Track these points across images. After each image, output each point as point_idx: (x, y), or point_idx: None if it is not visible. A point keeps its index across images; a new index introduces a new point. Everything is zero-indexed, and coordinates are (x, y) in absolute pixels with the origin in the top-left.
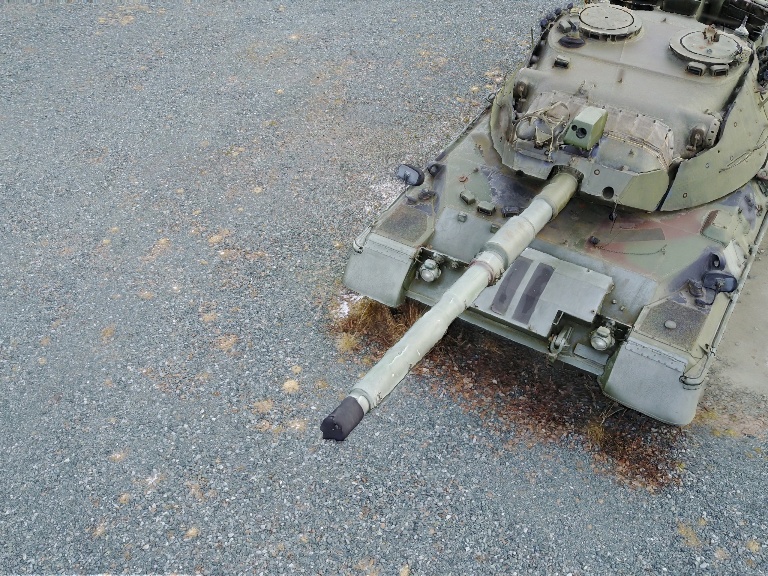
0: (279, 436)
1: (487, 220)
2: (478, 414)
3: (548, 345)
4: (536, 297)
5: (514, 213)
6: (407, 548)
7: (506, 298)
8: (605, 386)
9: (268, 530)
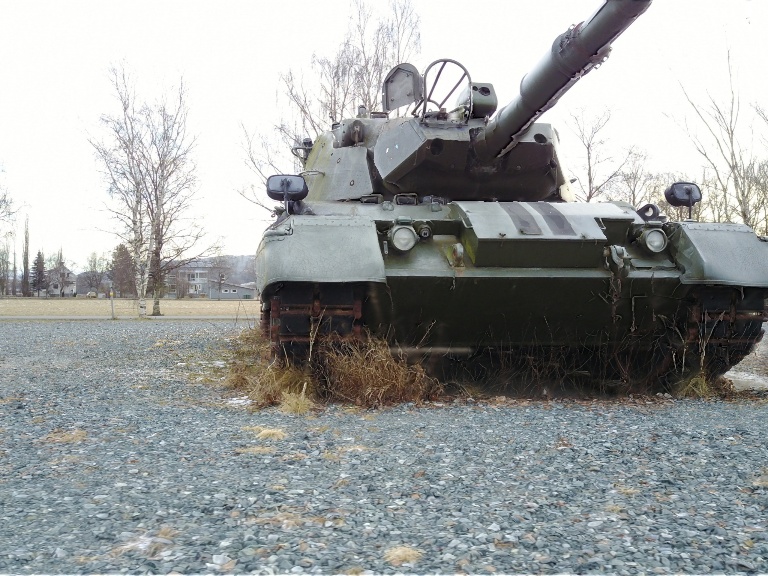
0: (345, 458)
1: None
2: (566, 408)
3: (607, 261)
4: (559, 214)
5: (439, 200)
6: (763, 460)
7: (528, 222)
8: (705, 269)
9: (548, 504)
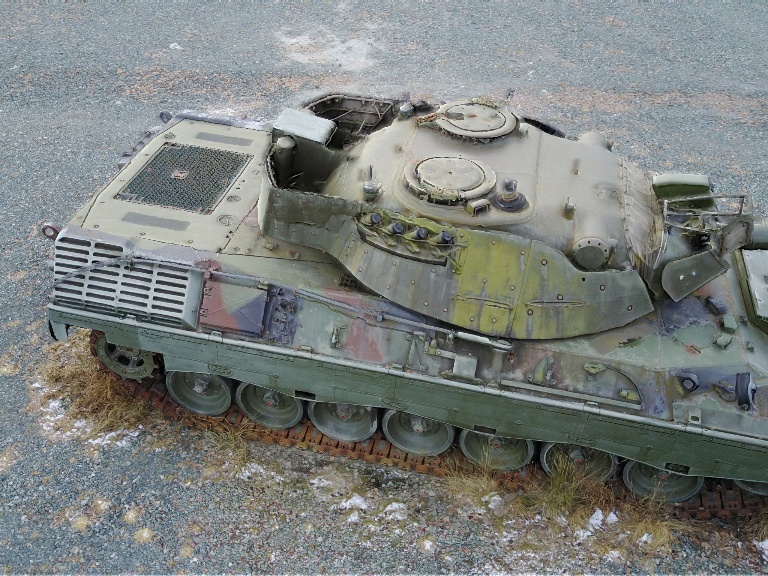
0: None
1: (740, 327)
2: None
3: None
4: None
5: None
6: None
7: None
8: None
9: None
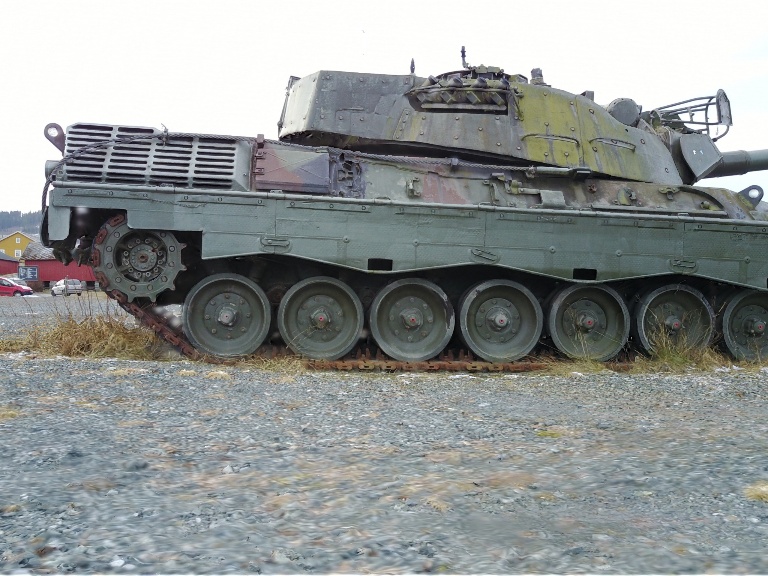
0: None
1: None
2: None
3: None
4: None
5: None
6: None
7: None
8: None
9: None
